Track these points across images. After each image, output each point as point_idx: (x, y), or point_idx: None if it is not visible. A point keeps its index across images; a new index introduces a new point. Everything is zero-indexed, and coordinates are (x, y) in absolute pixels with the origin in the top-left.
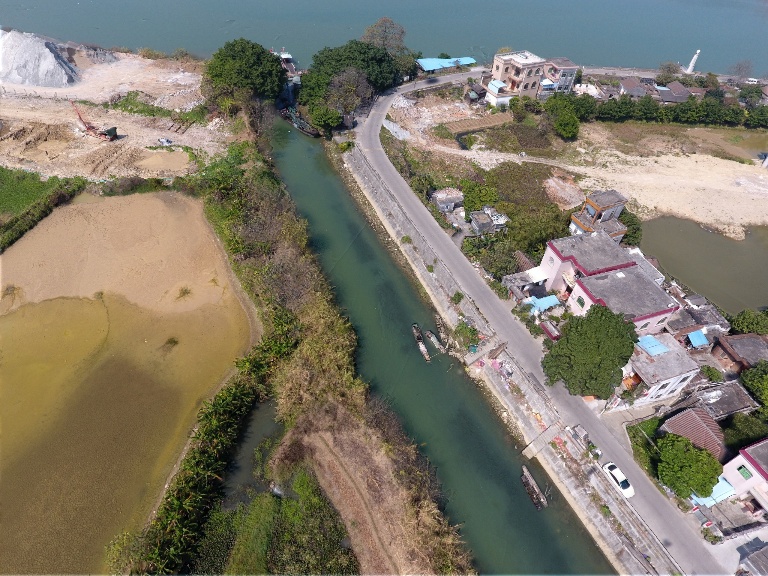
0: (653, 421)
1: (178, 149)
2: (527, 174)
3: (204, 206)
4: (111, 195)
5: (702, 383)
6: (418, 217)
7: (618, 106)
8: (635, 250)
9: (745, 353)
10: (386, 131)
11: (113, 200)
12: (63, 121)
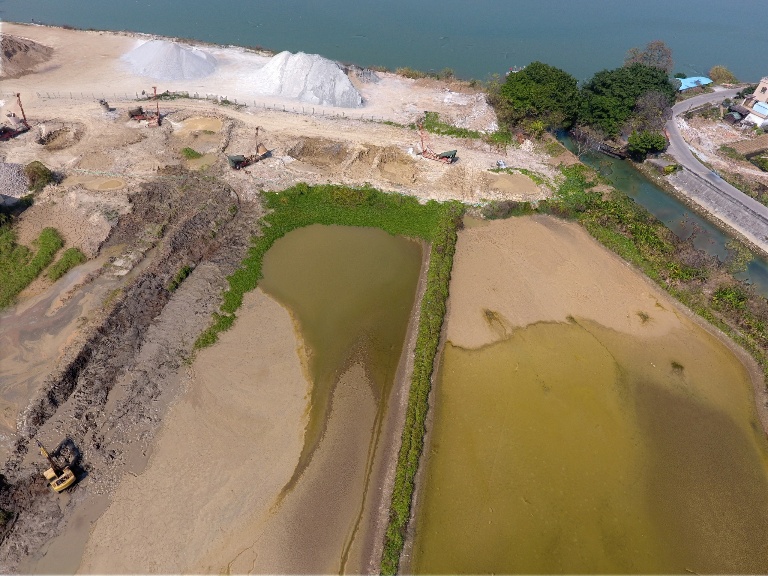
0: None
1: (516, 172)
2: None
3: (592, 230)
4: (493, 218)
5: None
6: None
7: None
8: None
9: None
10: (694, 154)
11: (499, 223)
12: (388, 143)
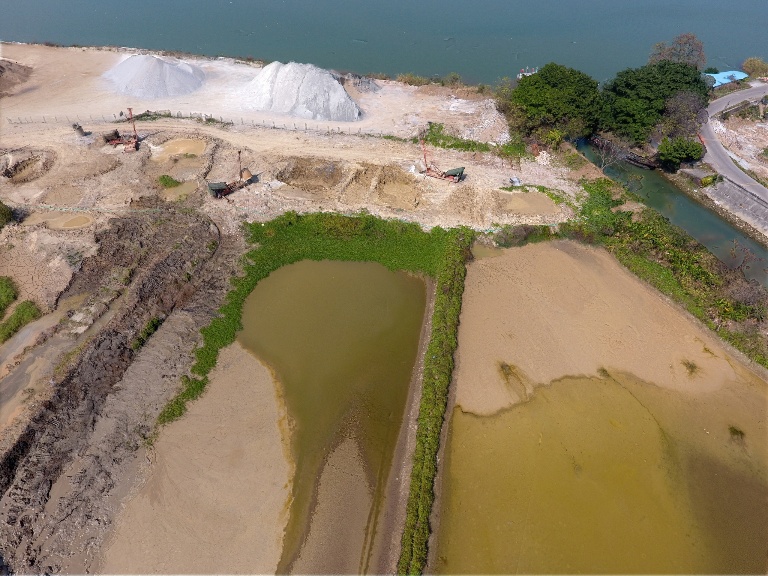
0: None
1: (532, 189)
2: None
3: (622, 258)
4: (508, 246)
5: None
6: None
7: None
8: None
9: None
10: (734, 161)
11: (514, 252)
12: (388, 160)
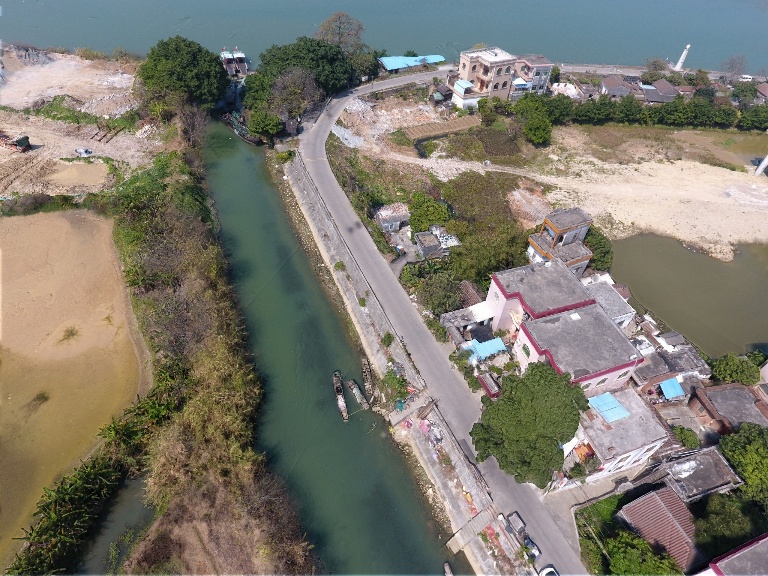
0: (611, 500)
1: (98, 161)
2: (490, 185)
3: (113, 227)
4: (10, 215)
5: (673, 449)
6: (354, 239)
7: (596, 107)
8: (604, 276)
9: (727, 409)
10: (335, 138)
11: (11, 221)
12: None
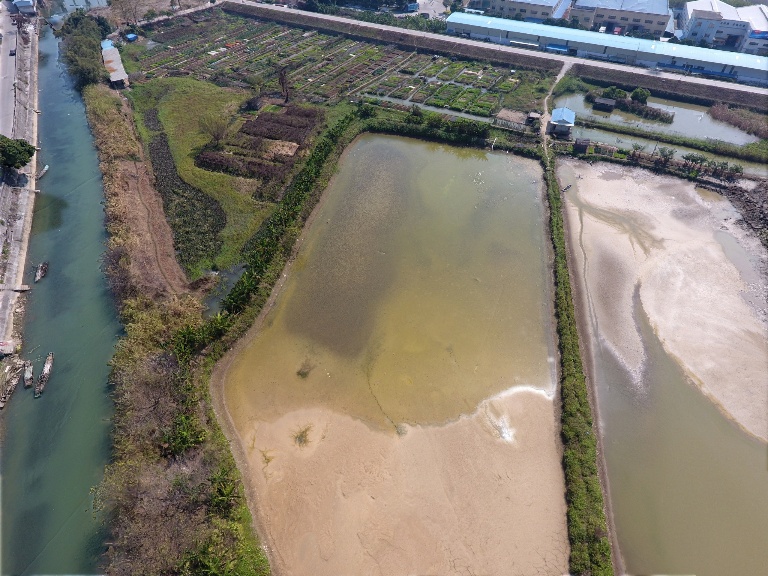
0: None
1: None
2: None
3: None
4: None
5: None
6: None
7: None
8: None
9: None
10: None
11: None
12: None
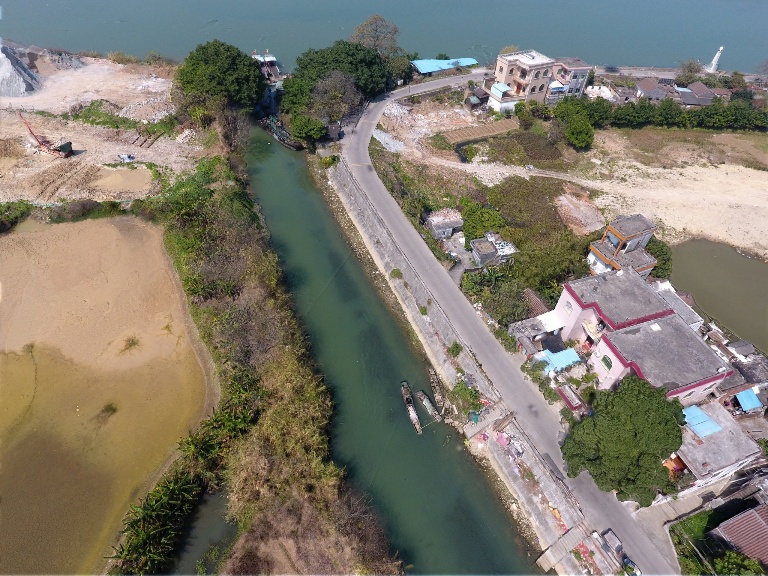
0: (701, 517)
1: (141, 166)
2: (536, 190)
3: (164, 234)
4: (59, 222)
5: (760, 464)
6: (410, 246)
7: (636, 111)
8: (665, 284)
9: None
10: (376, 142)
11: (60, 228)
12: (15, 135)
